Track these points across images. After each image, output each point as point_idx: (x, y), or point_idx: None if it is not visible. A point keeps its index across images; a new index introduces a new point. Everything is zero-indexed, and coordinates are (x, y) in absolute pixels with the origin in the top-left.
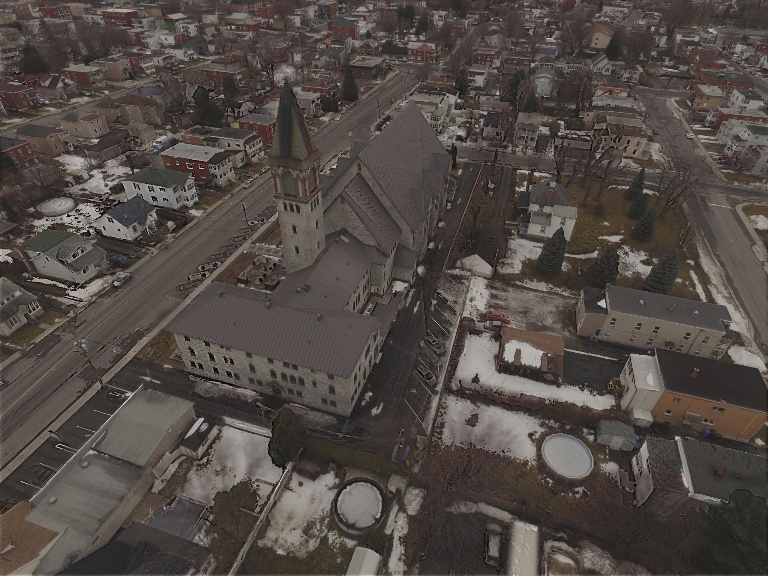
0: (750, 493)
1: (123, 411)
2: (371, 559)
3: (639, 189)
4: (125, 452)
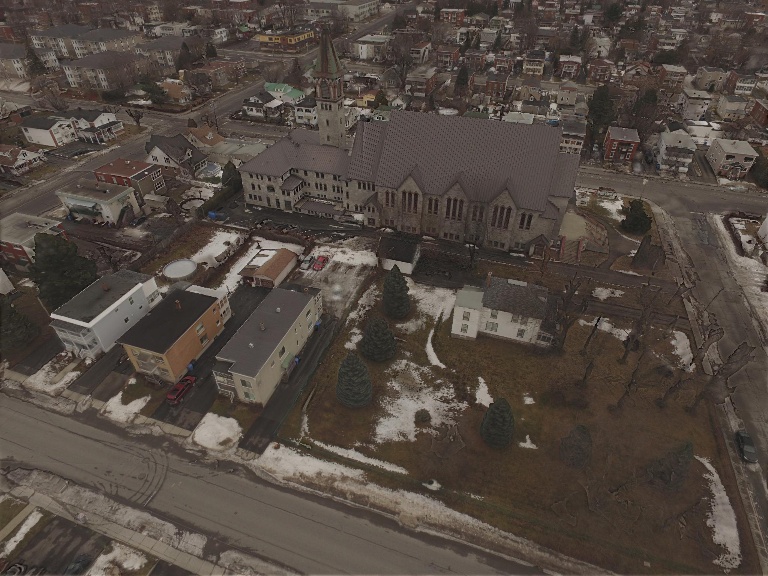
0: (71, 251)
1: (260, 144)
2: (162, 199)
3: (666, 472)
4: (240, 149)
